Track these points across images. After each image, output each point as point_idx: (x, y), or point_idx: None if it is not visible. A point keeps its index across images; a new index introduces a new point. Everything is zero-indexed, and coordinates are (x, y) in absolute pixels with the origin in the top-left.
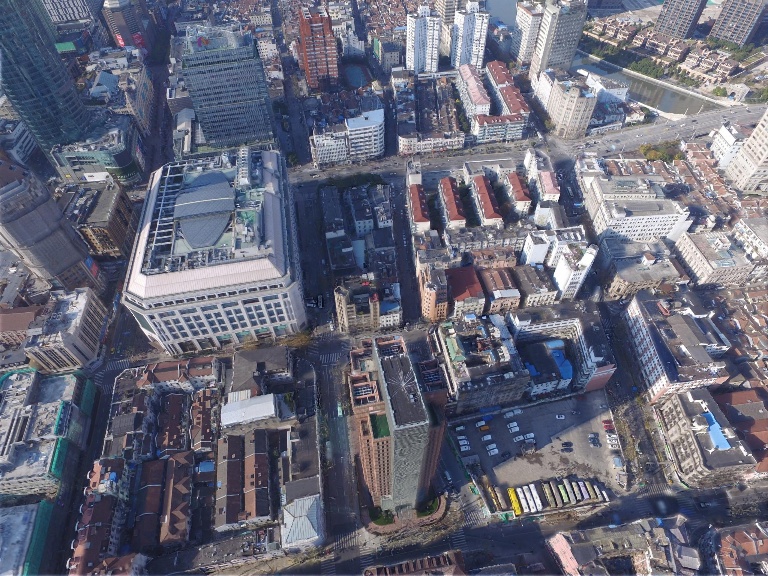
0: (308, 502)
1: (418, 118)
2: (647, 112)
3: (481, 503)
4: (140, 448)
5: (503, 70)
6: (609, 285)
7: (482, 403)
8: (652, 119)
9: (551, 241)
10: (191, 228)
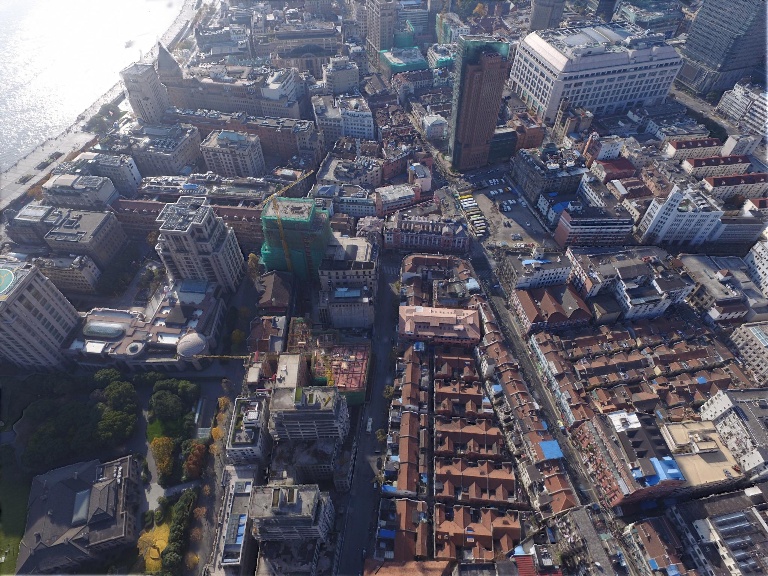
0: (444, 120)
1: None
2: None
3: None
4: None
5: None
6: None
7: None
8: None
9: None
10: (577, 37)
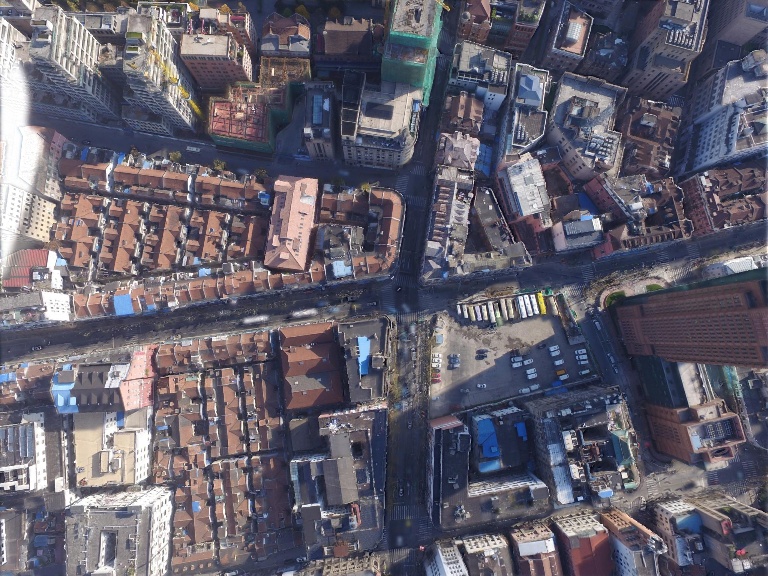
0: None
1: None
2: None
3: (570, 302)
4: None
5: None
6: (382, 575)
7: None
8: None
9: None
10: None
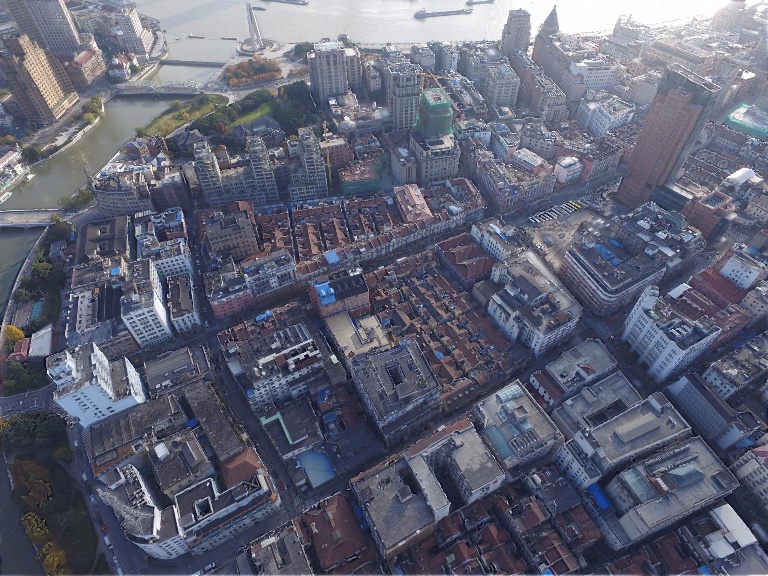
0: None
1: None
2: None
3: None
4: (764, 163)
5: None
6: None
7: None
8: None
9: None
10: None
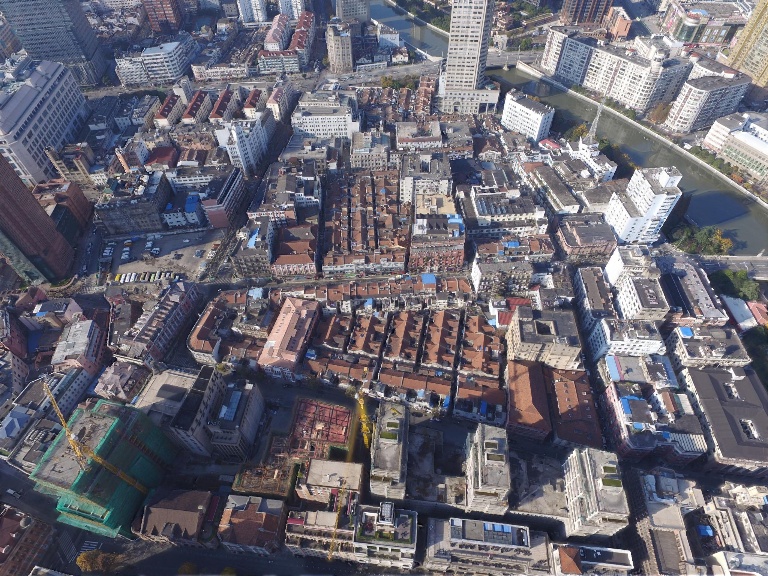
0: None
1: (223, 54)
2: (412, 54)
3: (96, 282)
4: None
5: (305, 18)
6: None
7: (128, 226)
8: (414, 60)
9: (230, 128)
10: None
